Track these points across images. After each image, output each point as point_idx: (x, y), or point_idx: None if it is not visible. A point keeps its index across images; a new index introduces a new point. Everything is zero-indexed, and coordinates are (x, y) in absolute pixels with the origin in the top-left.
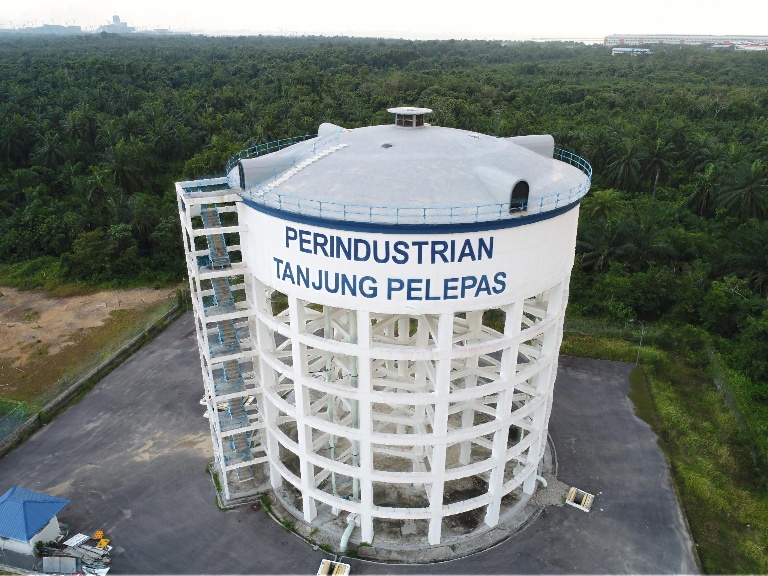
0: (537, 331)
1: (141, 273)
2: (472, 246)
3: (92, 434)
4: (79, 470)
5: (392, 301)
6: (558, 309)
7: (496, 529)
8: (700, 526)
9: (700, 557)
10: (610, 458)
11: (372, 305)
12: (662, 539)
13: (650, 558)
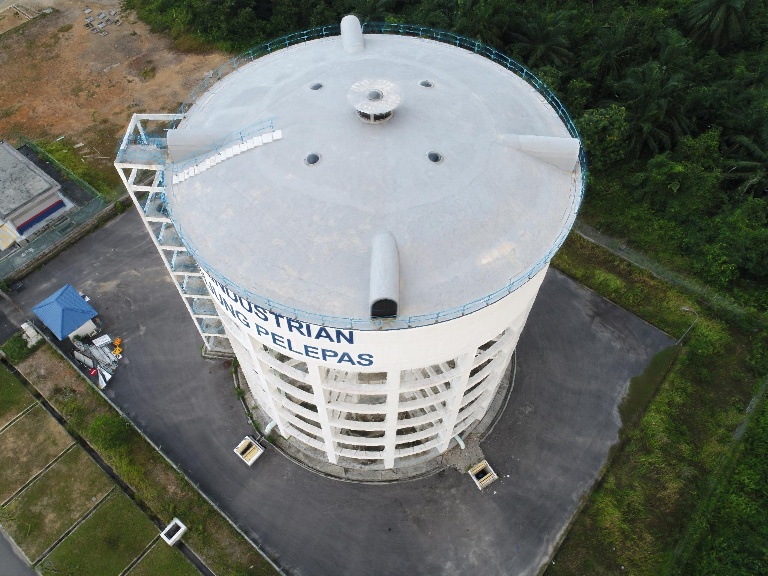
0: (425, 386)
1: (254, 39)
2: (329, 332)
3: (146, 238)
4: (126, 273)
5: (262, 337)
6: (465, 368)
7: (390, 471)
8: (572, 548)
9: (545, 575)
10: (548, 444)
11: (248, 331)
12: (525, 544)
13: (499, 555)
